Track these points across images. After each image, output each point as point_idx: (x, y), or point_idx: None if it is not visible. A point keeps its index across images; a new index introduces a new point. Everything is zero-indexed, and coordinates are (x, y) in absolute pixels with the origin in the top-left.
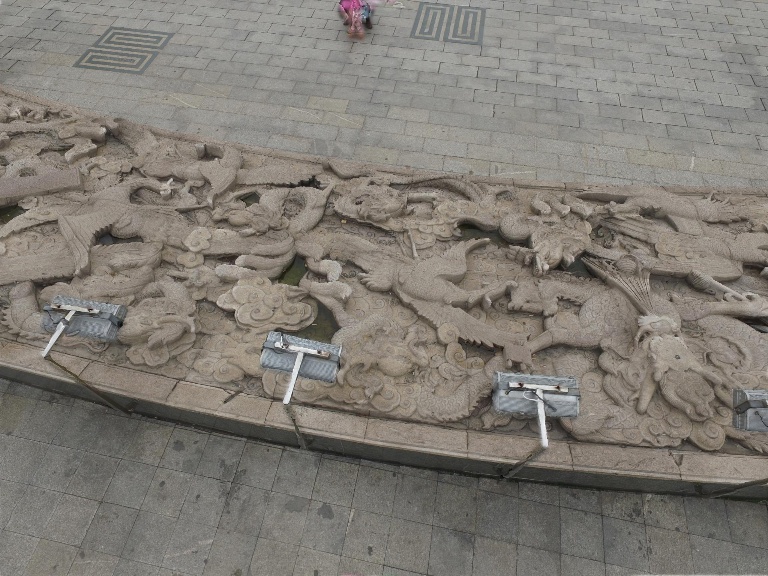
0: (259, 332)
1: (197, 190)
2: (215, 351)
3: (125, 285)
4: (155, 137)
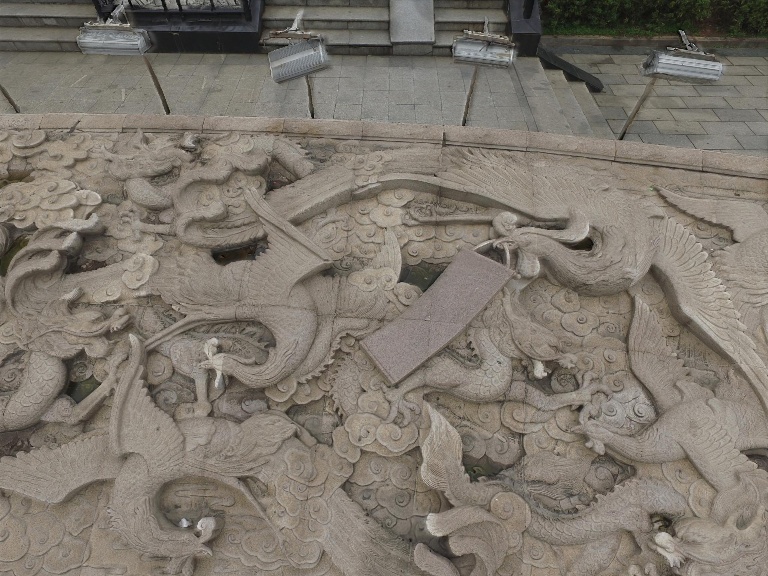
0: (52, 176)
1: (188, 400)
2: (97, 158)
3: (187, 176)
4: (338, 567)
